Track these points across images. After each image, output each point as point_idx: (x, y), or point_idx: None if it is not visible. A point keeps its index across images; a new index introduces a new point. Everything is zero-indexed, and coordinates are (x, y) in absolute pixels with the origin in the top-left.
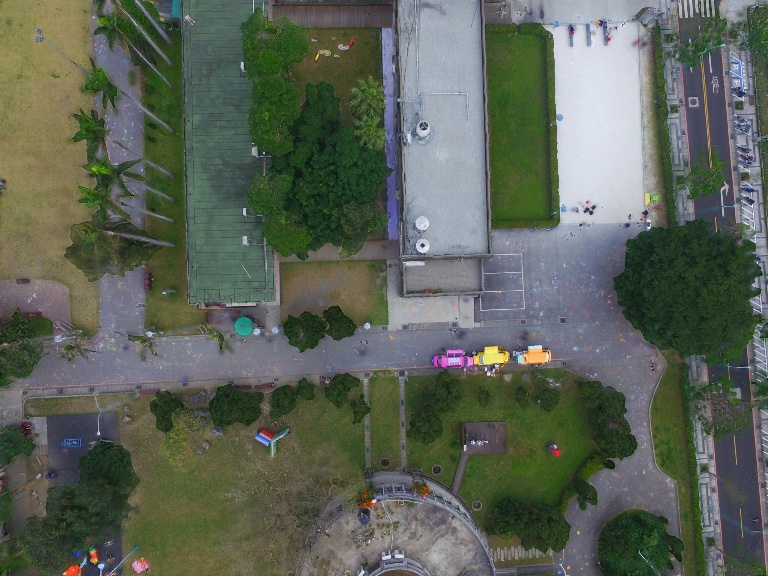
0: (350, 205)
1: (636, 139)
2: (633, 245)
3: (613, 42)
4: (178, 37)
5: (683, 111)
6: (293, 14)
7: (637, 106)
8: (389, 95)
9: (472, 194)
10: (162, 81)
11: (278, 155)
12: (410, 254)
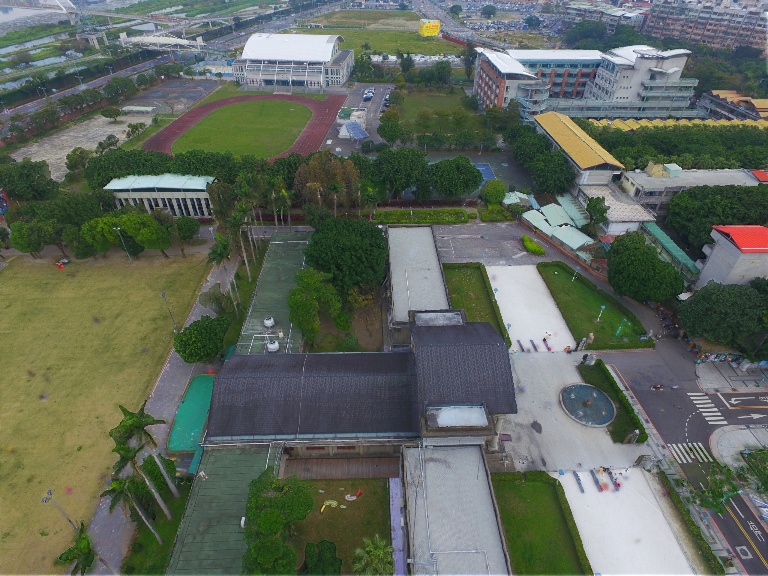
0: None
1: None
2: None
3: (624, 487)
4: (187, 490)
5: (738, 564)
6: (304, 467)
7: (682, 559)
8: (398, 550)
9: None
10: (154, 537)
11: None
12: None
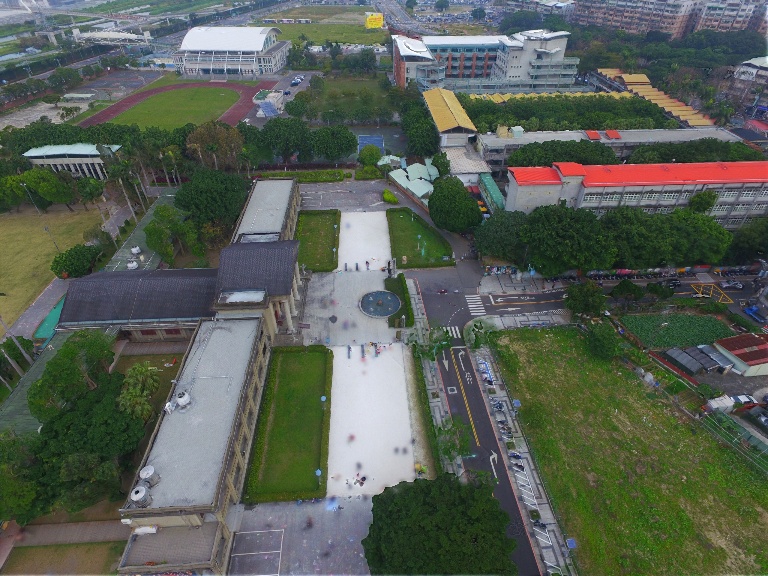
0: (79, 453)
1: (404, 419)
2: (378, 500)
3: (383, 355)
4: None
5: (444, 397)
6: (139, 347)
7: (404, 395)
8: None
9: (214, 451)
10: (10, 391)
11: (45, 421)
12: (128, 507)
